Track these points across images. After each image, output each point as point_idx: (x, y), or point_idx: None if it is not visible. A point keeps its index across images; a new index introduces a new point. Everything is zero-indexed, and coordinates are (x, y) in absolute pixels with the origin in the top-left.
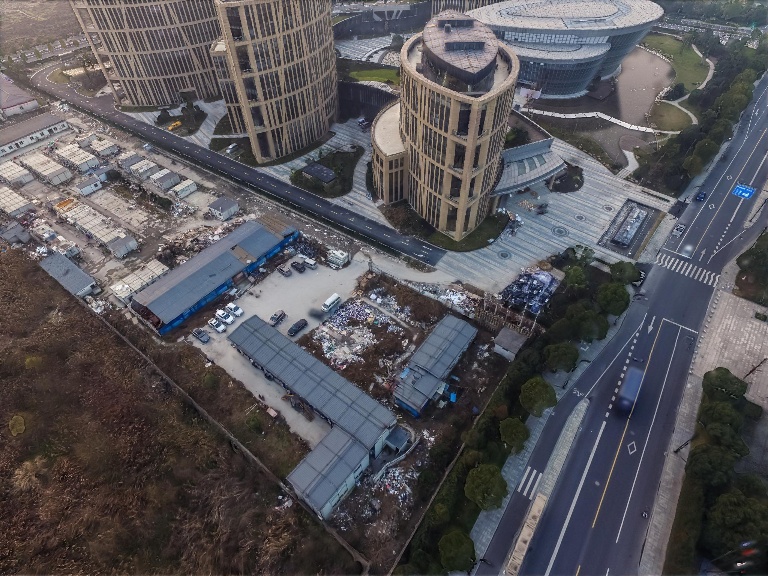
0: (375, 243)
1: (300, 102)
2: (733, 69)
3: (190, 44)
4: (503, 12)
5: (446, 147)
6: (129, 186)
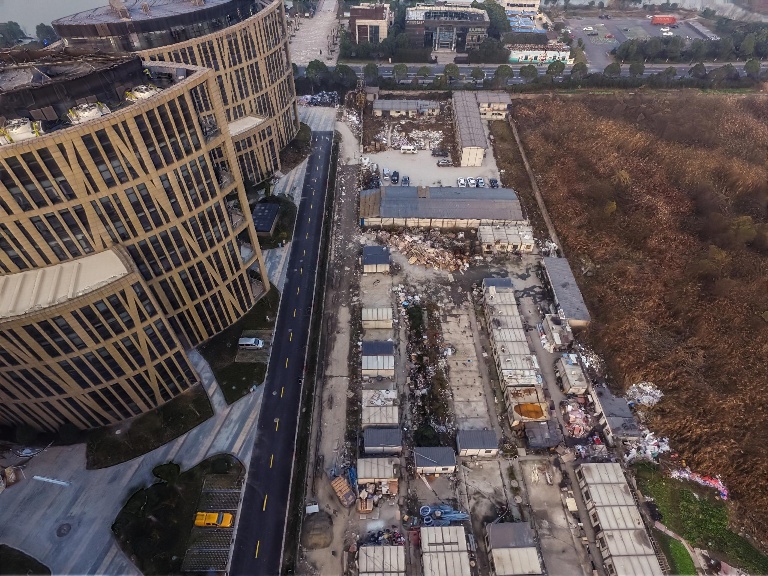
0: None
1: None
2: None
3: None
4: None
5: None
6: None
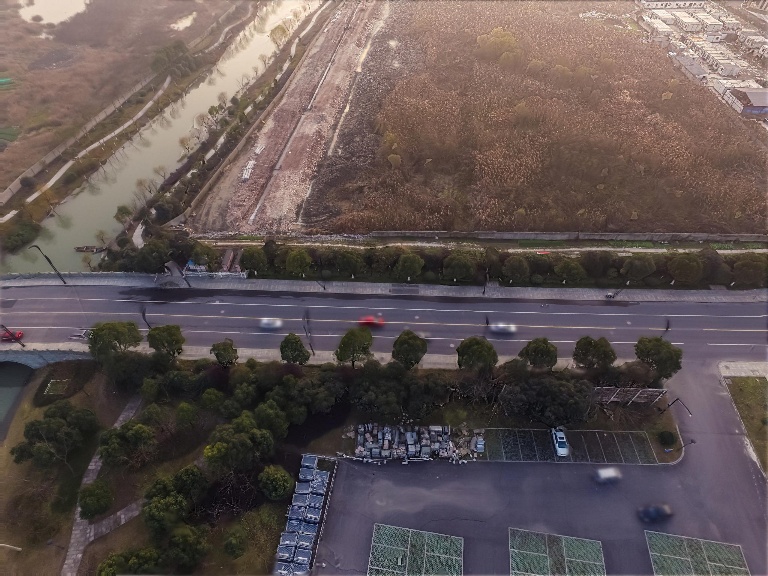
0: None
1: None
2: None
3: None
4: None
5: None
6: (741, 47)
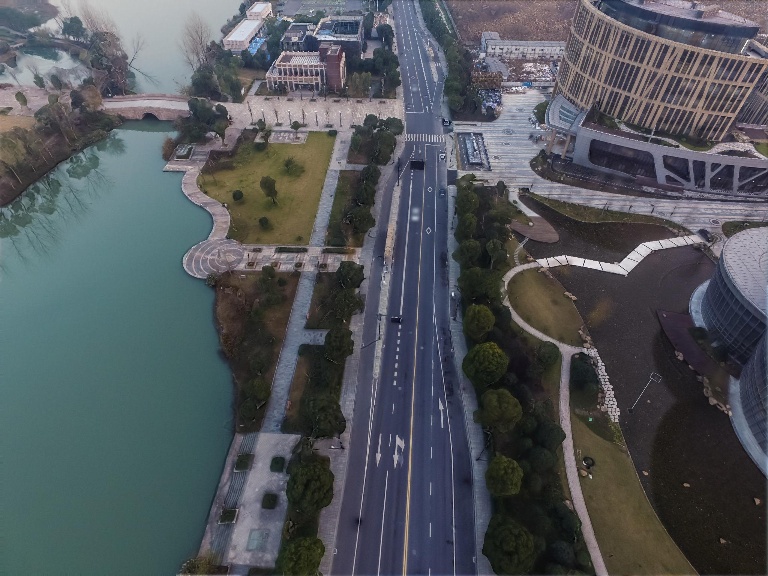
0: None
1: (767, 79)
2: (561, 568)
3: None
4: None
5: None
6: None
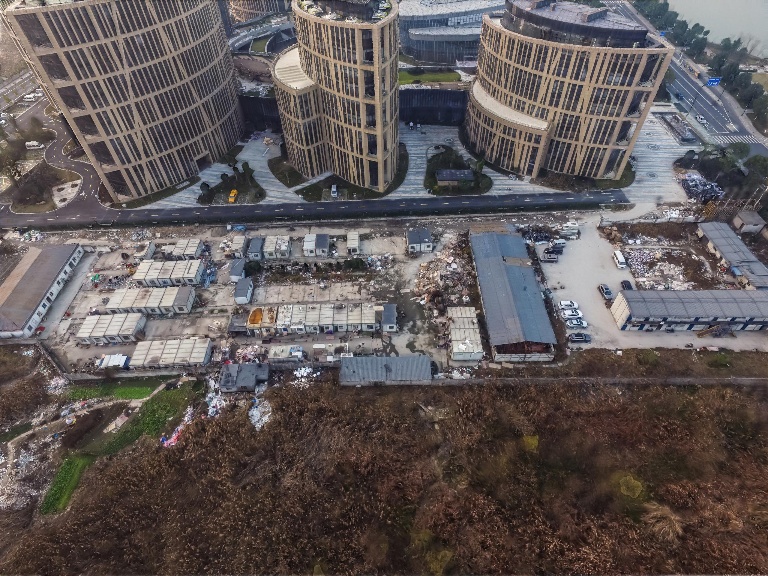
0: (577, 206)
1: None
2: None
3: (199, 99)
4: (426, 3)
5: (626, 99)
6: (286, 269)
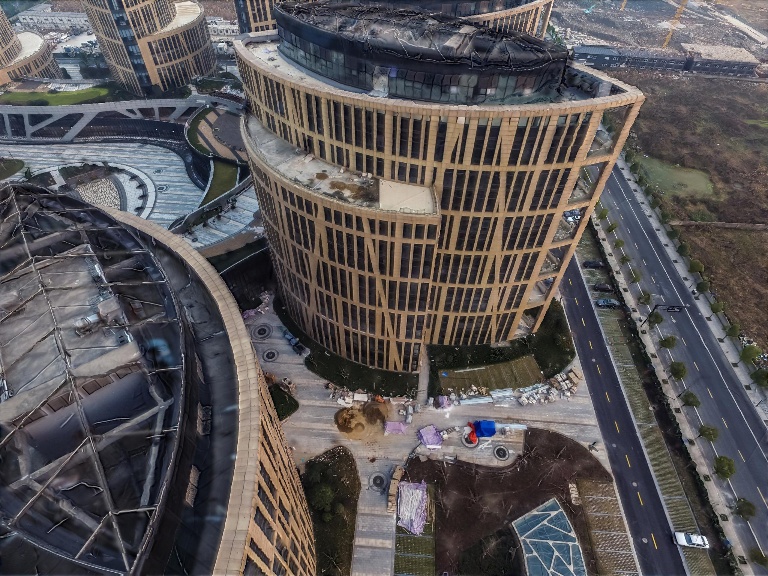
0: None
1: None
2: None
3: None
4: None
5: None
6: None
